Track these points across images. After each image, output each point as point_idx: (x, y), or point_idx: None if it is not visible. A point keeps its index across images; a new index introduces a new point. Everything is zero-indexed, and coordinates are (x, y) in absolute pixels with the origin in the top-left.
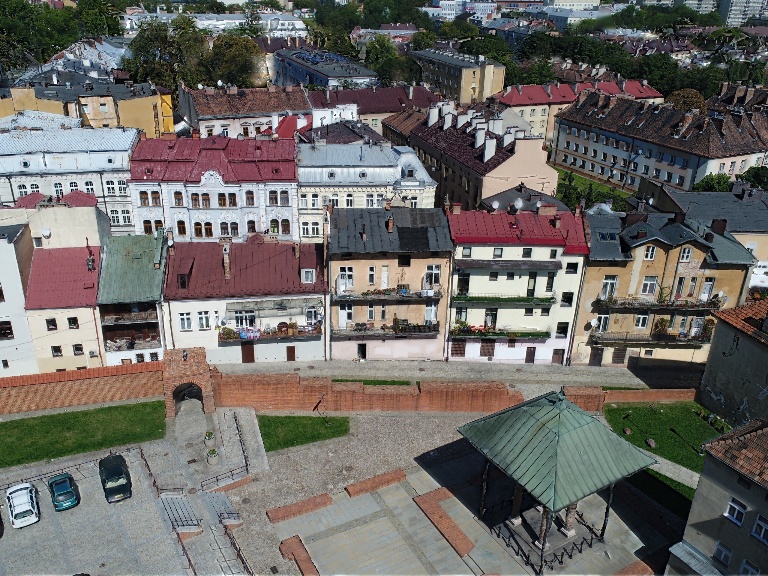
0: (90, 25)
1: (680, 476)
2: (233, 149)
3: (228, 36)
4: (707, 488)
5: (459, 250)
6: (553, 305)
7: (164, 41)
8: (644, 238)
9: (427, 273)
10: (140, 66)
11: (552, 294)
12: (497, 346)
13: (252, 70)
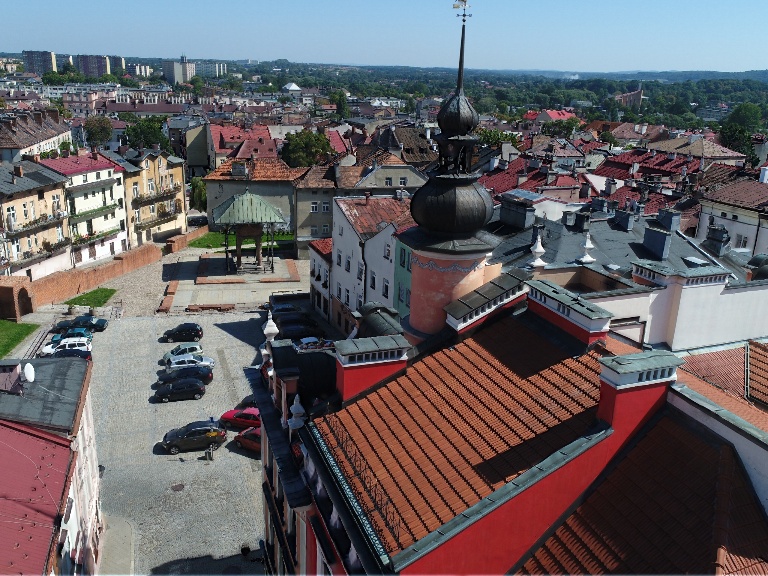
0: None
1: (249, 246)
2: None
3: None
4: (302, 205)
5: None
6: (116, 209)
7: None
8: (144, 155)
9: None
10: None
11: (114, 202)
12: (96, 247)
13: None
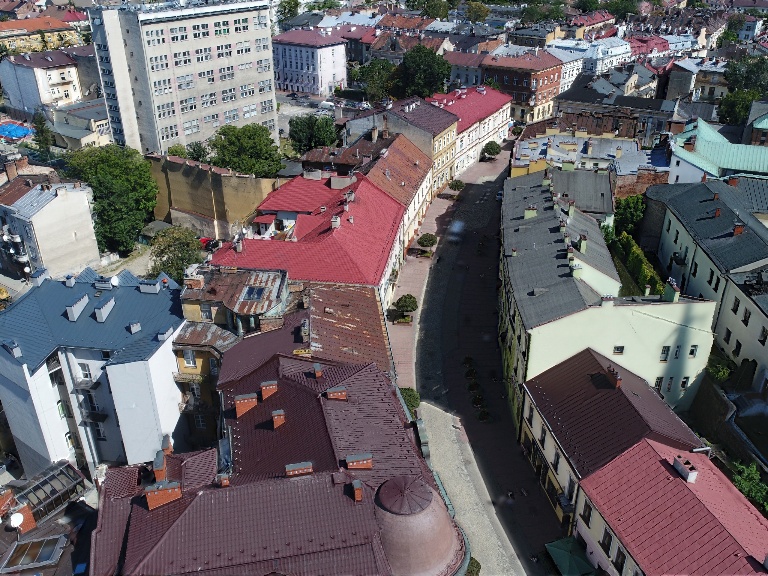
0: None
1: None
2: None
3: None
4: None
5: None
6: None
7: (440, 8)
8: None
9: None
10: None
11: None
12: None
13: None
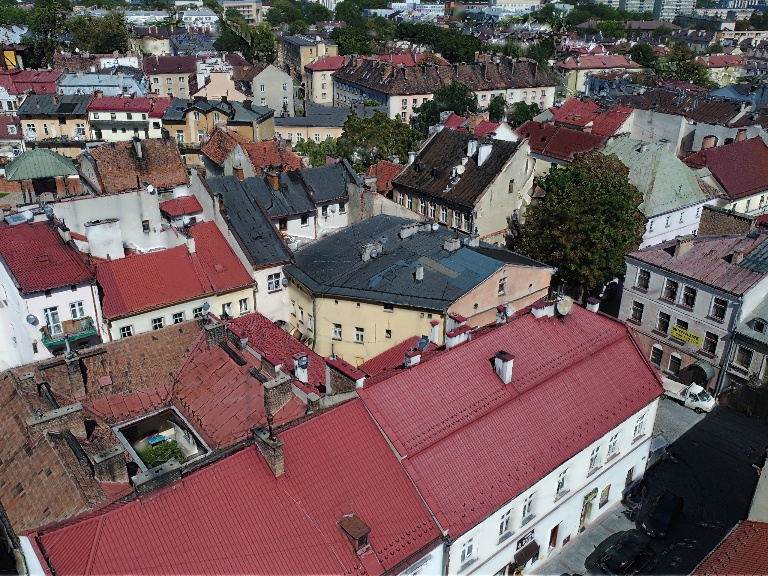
0: None
1: None
2: (21, 76)
3: (98, 19)
4: None
5: (92, 114)
6: None
7: (54, 24)
8: None
9: (78, 129)
10: (35, 42)
11: None
12: None
13: (117, 44)
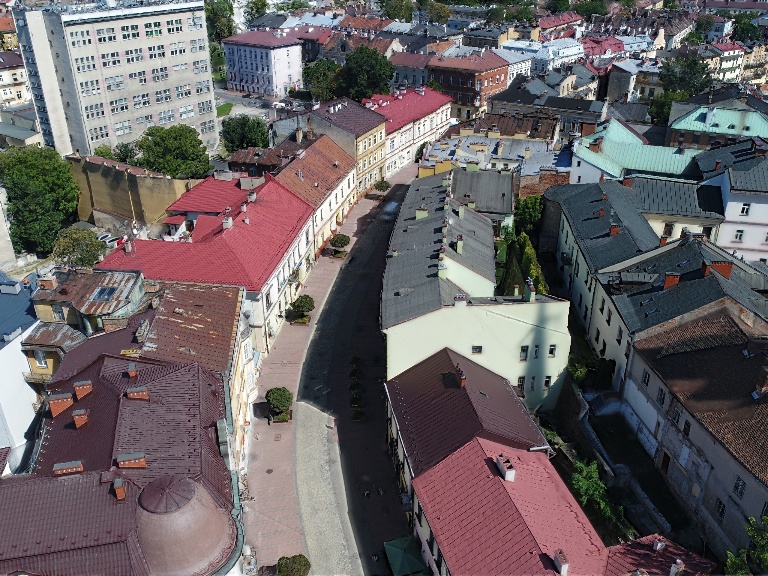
0: (216, 8)
1: None
2: None
3: None
4: None
5: None
6: None
7: (402, 9)
8: None
9: None
10: None
11: None
12: None
13: None
